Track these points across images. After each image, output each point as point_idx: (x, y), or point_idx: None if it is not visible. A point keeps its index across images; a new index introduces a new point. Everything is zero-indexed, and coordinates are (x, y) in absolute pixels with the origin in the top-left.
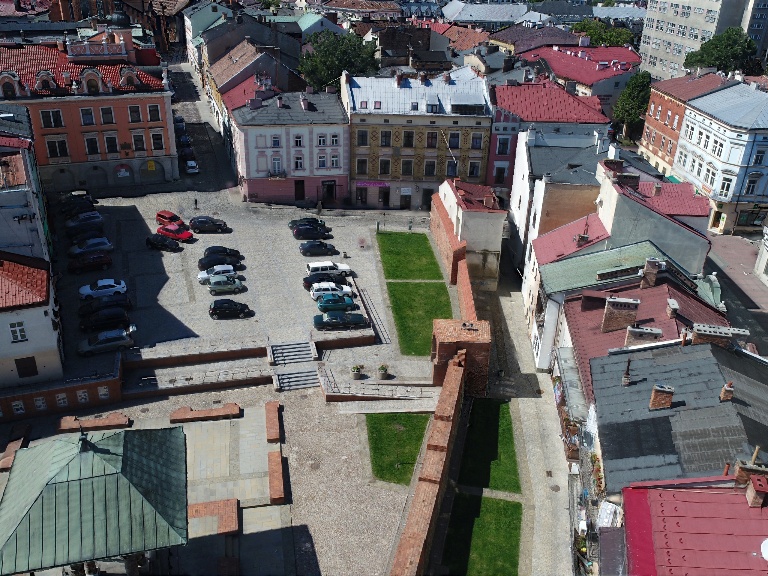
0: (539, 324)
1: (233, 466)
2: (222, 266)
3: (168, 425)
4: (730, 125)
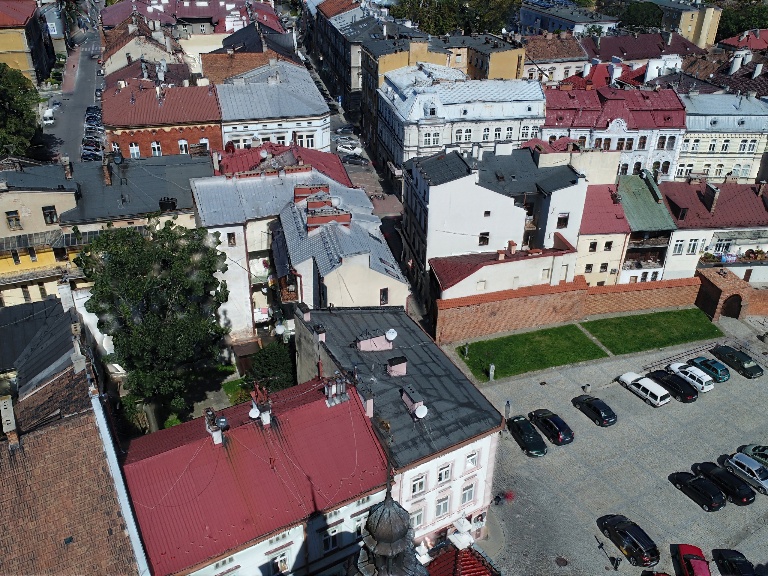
0: (639, 266)
1: None
2: (749, 461)
3: None
4: (320, 115)
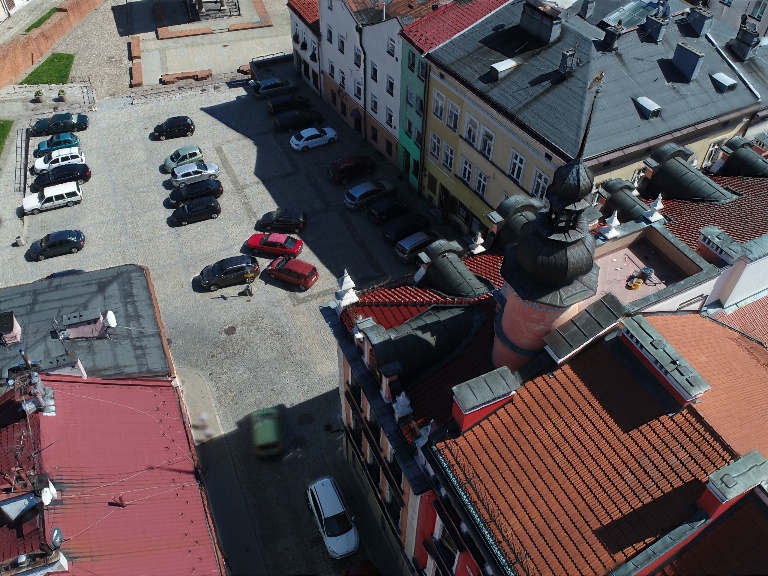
0: None
1: (164, 54)
2: (188, 167)
3: (213, 71)
4: None
